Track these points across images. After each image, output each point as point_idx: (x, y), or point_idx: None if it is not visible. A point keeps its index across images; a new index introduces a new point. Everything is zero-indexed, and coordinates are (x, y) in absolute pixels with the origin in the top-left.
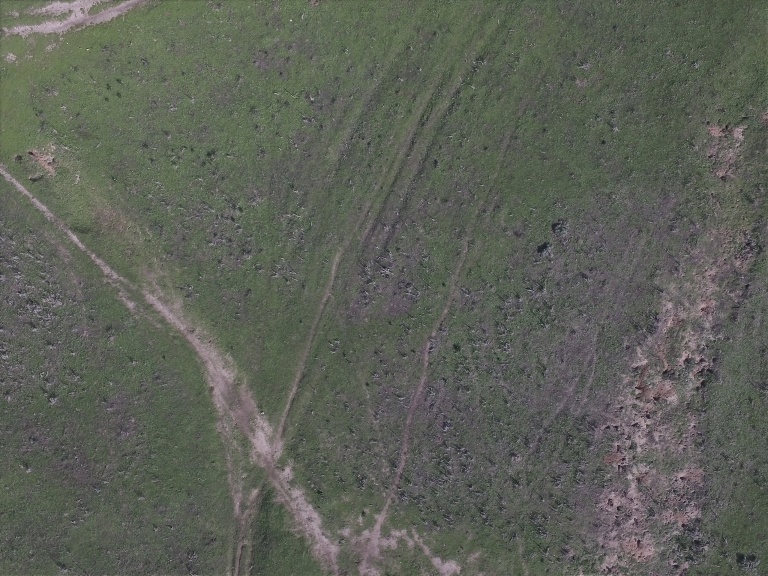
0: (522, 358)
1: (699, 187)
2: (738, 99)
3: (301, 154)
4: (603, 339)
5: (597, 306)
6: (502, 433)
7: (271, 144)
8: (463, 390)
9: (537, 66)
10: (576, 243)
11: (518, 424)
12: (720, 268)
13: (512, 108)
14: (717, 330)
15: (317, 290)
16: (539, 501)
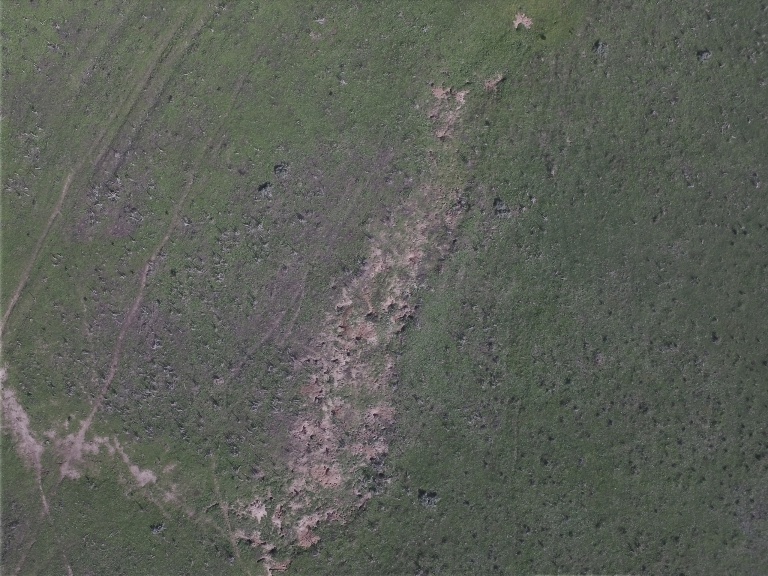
0: (234, 288)
1: (417, 144)
2: (463, 65)
3: (44, 78)
4: (312, 278)
5: (310, 246)
6: (208, 356)
7: (16, 66)
8: (175, 313)
9: (275, 16)
10: (296, 185)
11: (224, 349)
12: (431, 222)
13: (248, 53)
14: (421, 279)
15: (47, 206)
16: (236, 423)
